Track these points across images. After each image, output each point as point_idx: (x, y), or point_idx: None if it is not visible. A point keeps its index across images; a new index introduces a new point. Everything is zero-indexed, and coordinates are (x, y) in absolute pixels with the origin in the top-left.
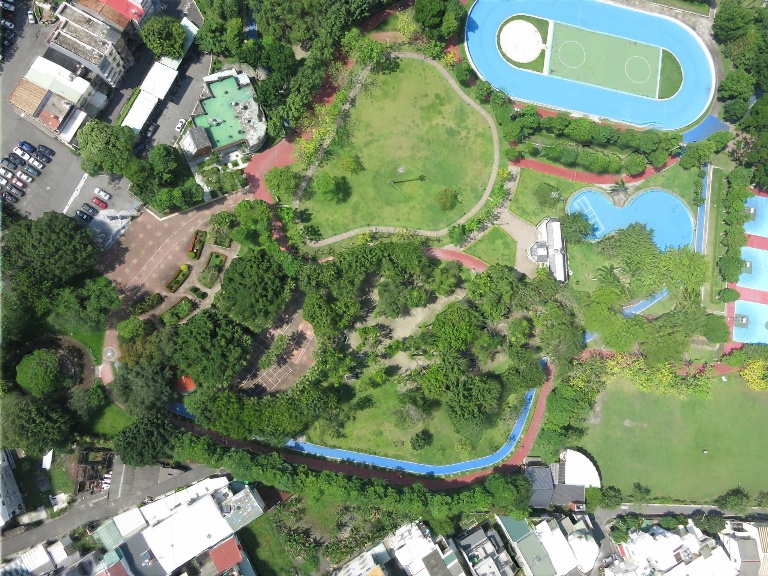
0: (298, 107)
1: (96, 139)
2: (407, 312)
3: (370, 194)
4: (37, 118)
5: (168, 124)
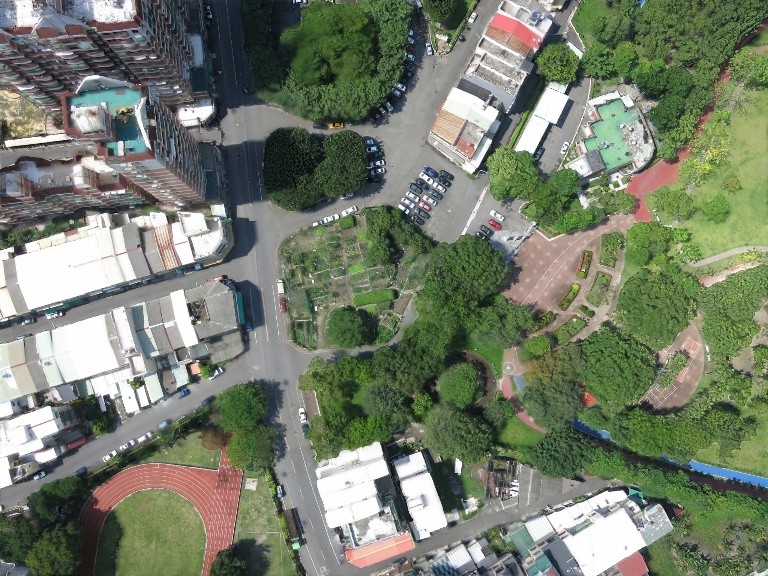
0: (692, 128)
1: (508, 165)
2: None
3: (748, 213)
4: (455, 146)
5: (552, 147)
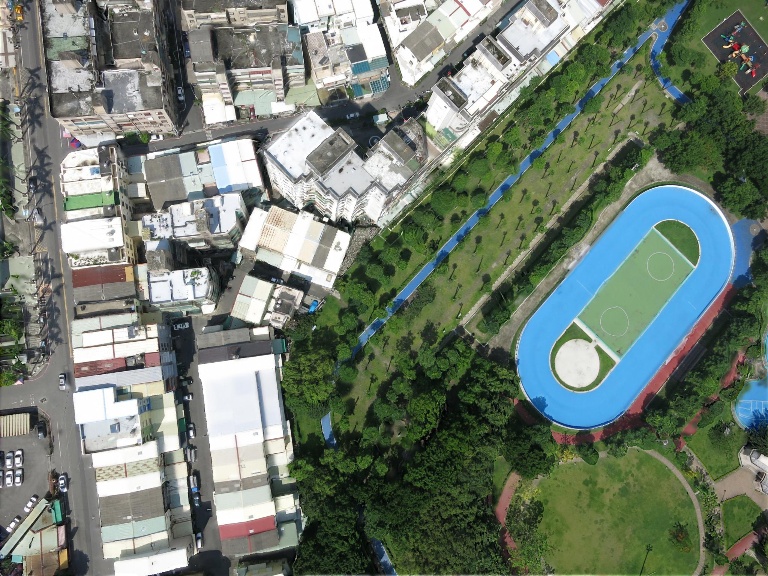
0: None
1: None
2: None
3: None
4: None
5: None
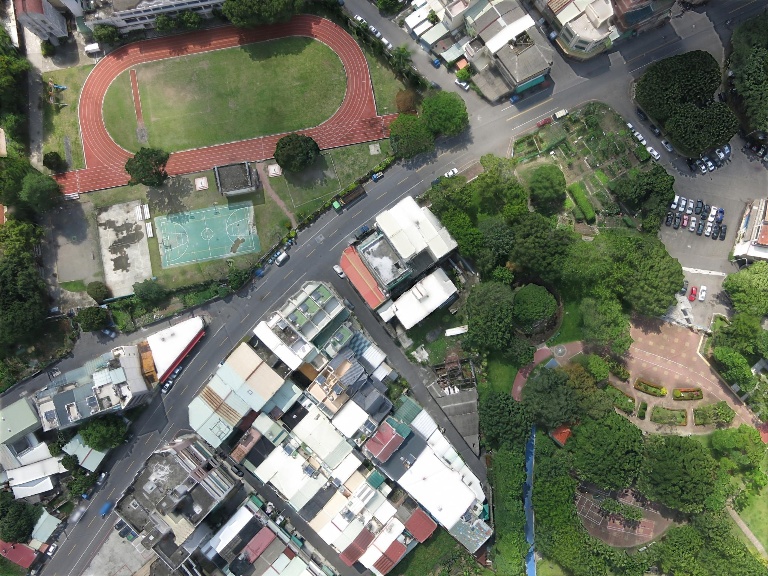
0: None
1: (765, 280)
2: None
3: None
4: (763, 224)
5: None
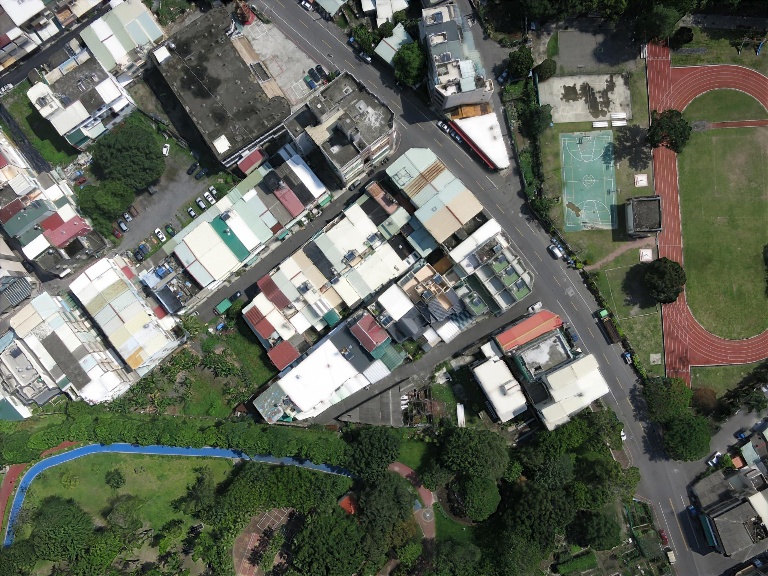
0: None
1: None
2: None
3: None
4: None
5: None
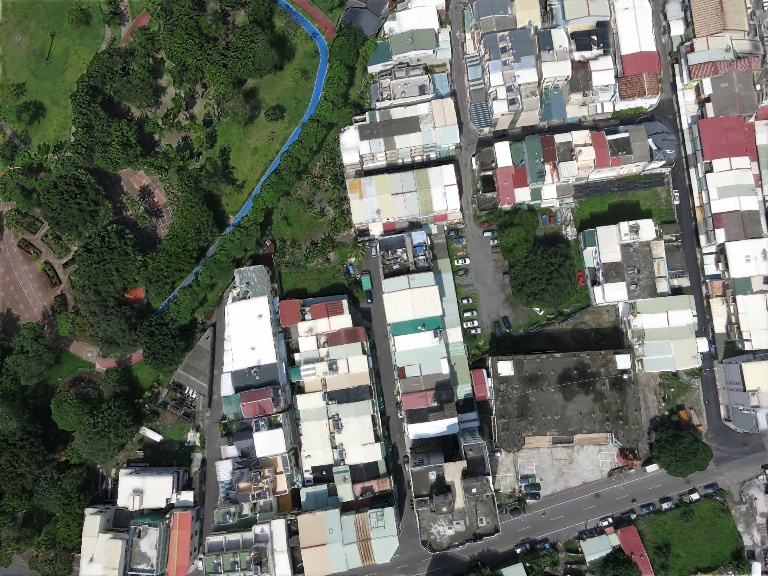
0: None
1: None
2: (162, 89)
3: (48, 85)
4: None
5: None
